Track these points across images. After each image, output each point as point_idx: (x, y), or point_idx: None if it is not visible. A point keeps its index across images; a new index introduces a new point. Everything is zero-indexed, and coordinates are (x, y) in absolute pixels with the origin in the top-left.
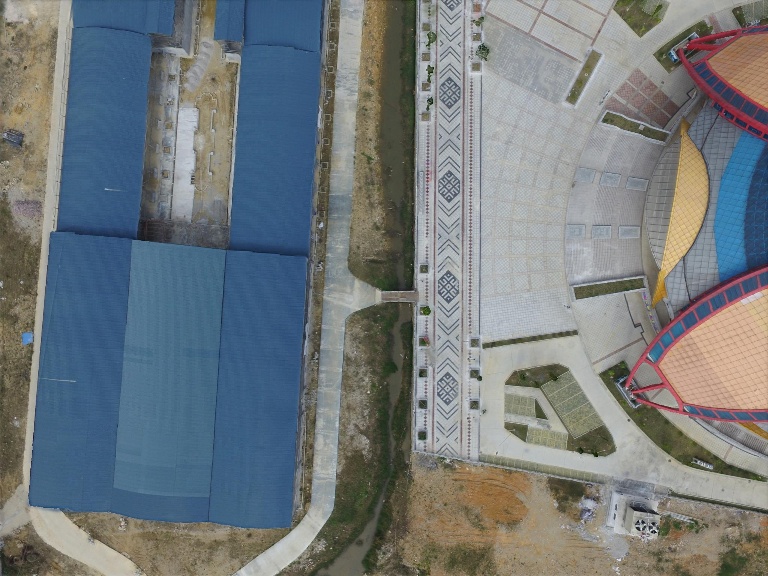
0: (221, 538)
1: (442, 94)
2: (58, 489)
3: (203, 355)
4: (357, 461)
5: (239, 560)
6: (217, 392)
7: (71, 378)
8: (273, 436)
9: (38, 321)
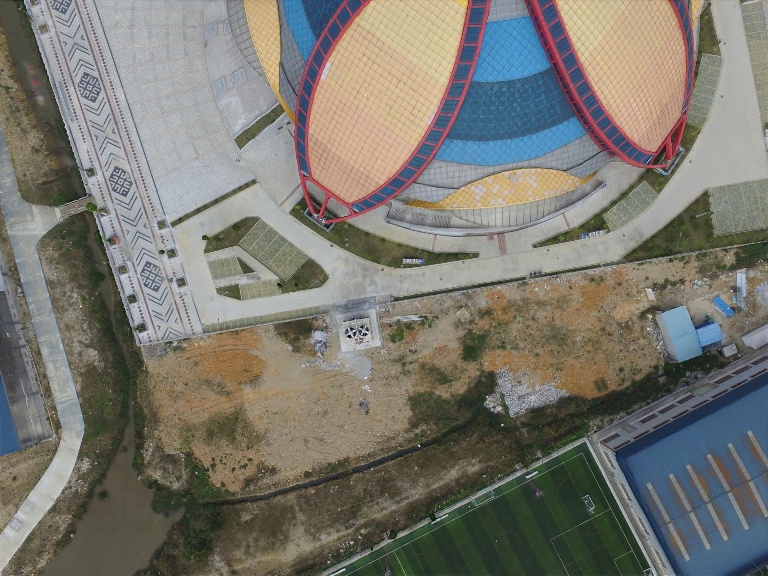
0: None
1: (53, 3)
2: None
3: None
4: (91, 374)
5: (12, 504)
6: None
7: None
8: None
9: None
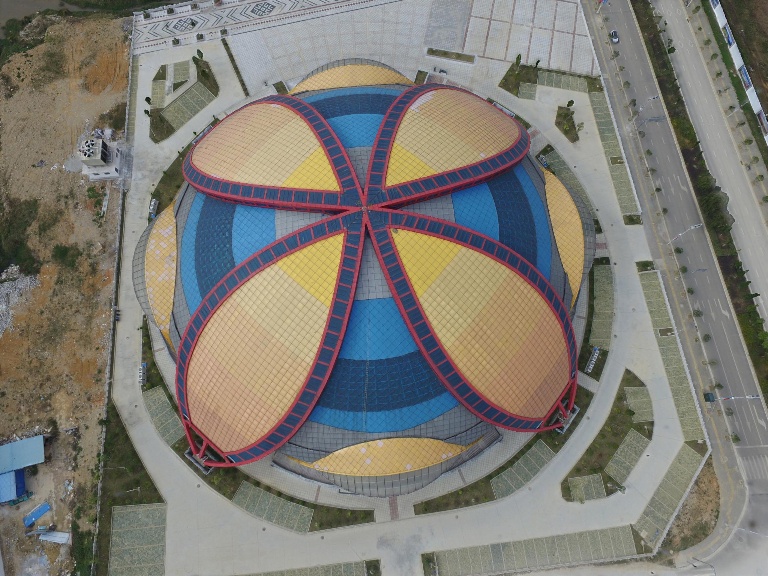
0: None
1: None
2: None
3: None
4: None
5: None
6: None
7: None
8: None
9: None
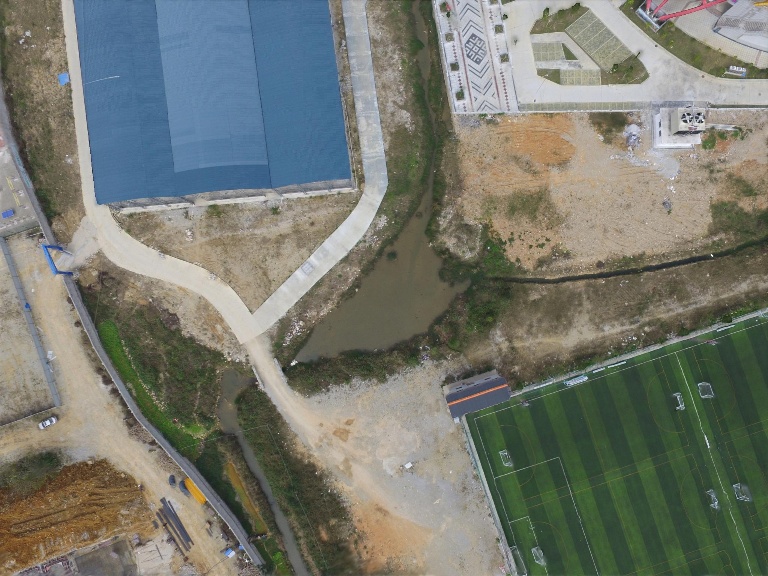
0: (285, 231)
1: None
2: (122, 179)
3: (236, 31)
4: (402, 135)
5: (307, 249)
6: (256, 65)
7: (114, 74)
8: (318, 94)
9: (71, 61)
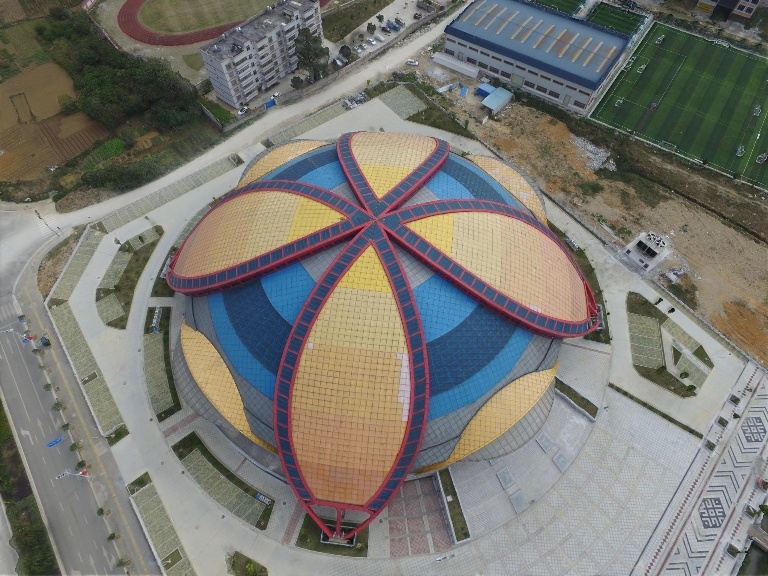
0: None
1: None
2: None
3: None
4: None
5: None
6: None
7: None
8: None
9: None
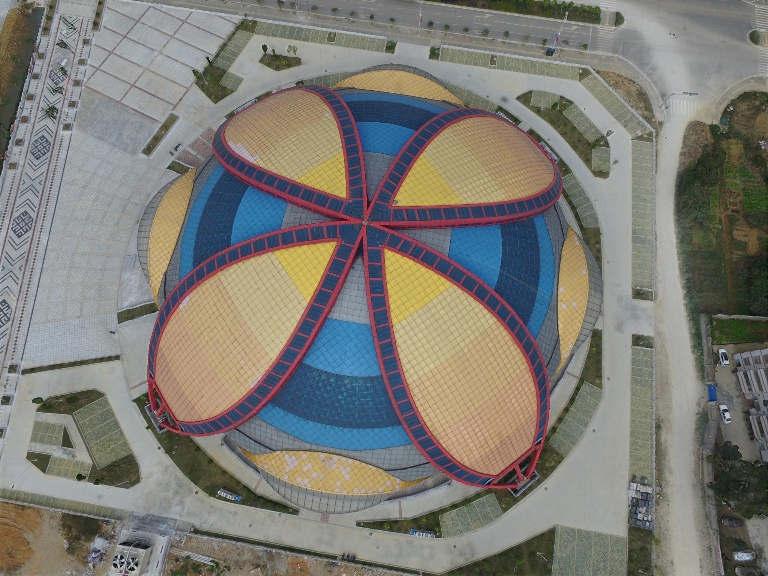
0: None
1: (33, 148)
2: None
3: None
4: None
5: None
6: None
7: None
8: None
9: None
